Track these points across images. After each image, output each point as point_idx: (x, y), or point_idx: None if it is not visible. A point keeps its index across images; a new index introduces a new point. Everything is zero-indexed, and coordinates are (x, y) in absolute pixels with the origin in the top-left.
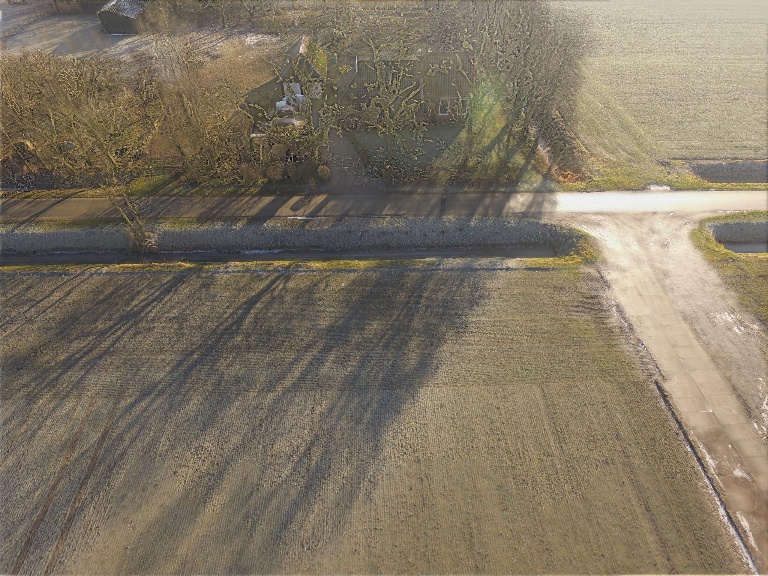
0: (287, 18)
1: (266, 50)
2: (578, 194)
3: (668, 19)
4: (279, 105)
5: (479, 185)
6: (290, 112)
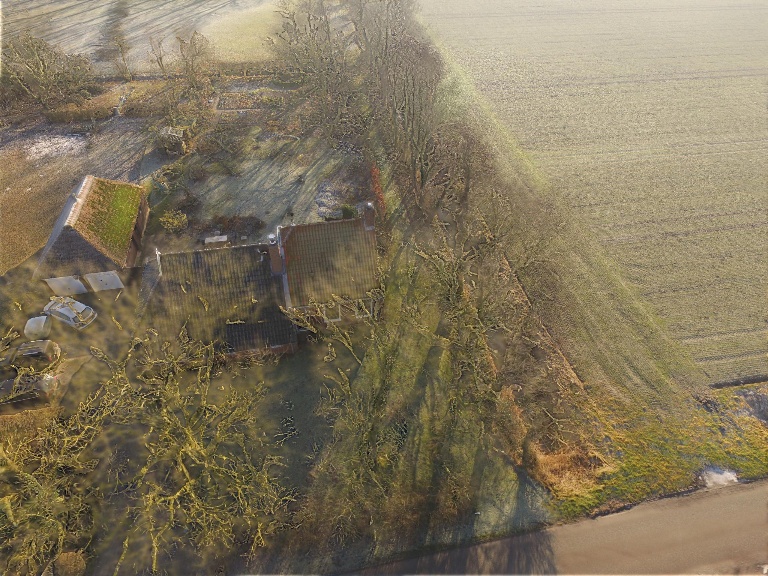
0: (101, 106)
1: (57, 171)
2: (588, 527)
3: (622, 75)
4: (30, 330)
5: (402, 531)
6: (41, 356)
